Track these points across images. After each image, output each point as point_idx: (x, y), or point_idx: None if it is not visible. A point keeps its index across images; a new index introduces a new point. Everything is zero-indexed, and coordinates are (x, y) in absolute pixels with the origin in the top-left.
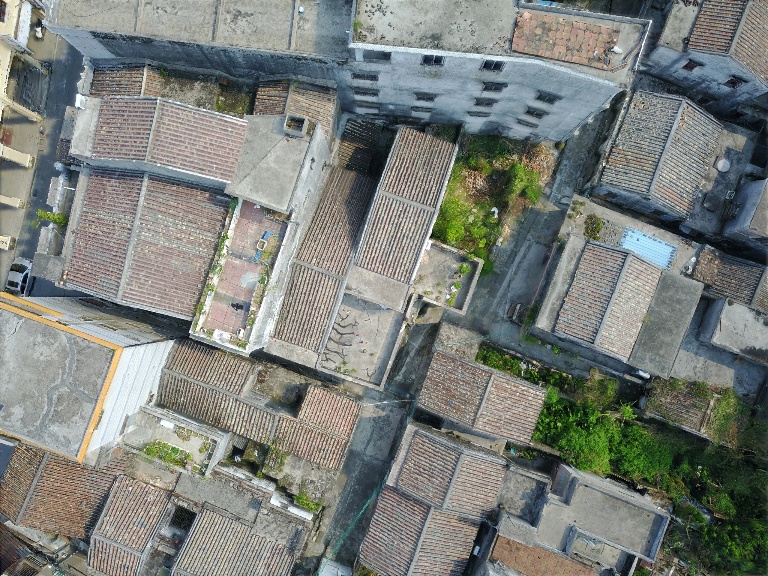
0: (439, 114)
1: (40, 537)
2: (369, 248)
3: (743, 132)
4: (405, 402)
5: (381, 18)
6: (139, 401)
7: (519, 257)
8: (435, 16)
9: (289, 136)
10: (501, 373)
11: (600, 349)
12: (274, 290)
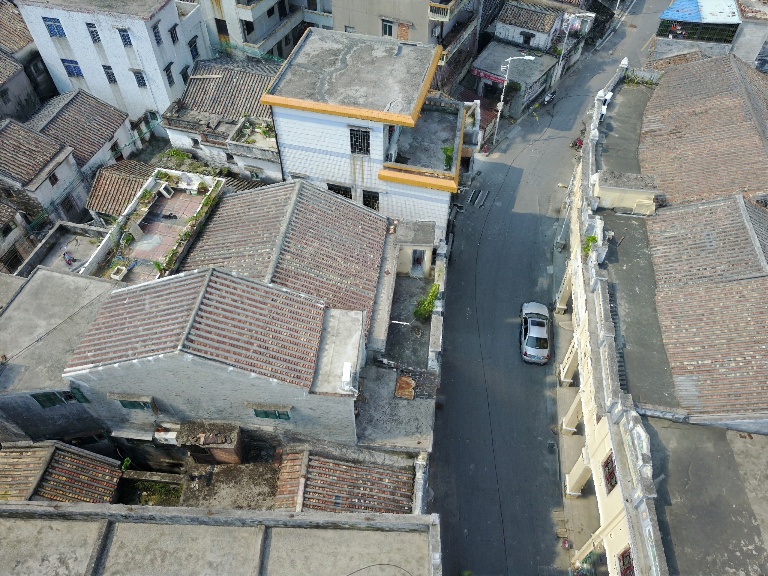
0: None
1: None
2: None
3: None
4: None
5: None
6: None
7: None
8: None
9: None
10: None
11: None
12: None
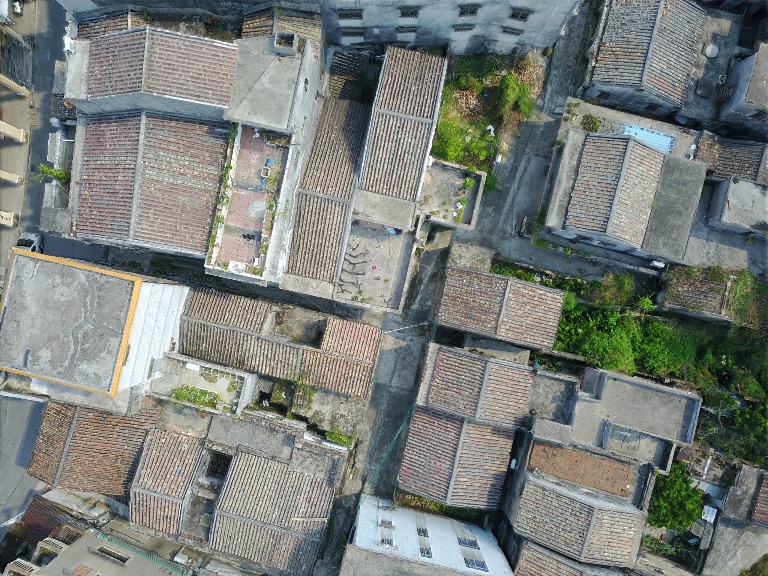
0: (424, 33)
1: (79, 506)
2: (371, 170)
3: (727, 16)
4: (424, 330)
5: None
6: (162, 346)
7: (520, 172)
8: None
9: (280, 55)
10: (517, 280)
11: (613, 237)
12: (283, 219)
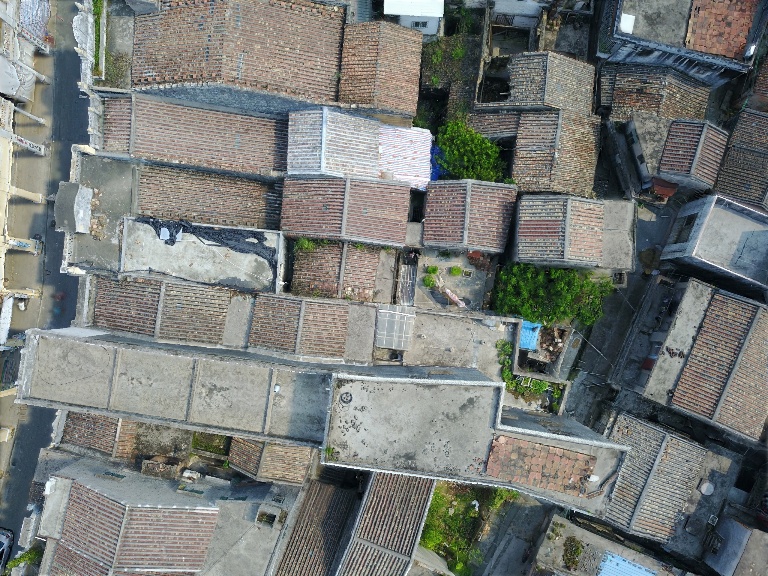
0: None
1: None
2: None
3: (728, 454)
4: None
5: (355, 434)
6: None
7: (499, 551)
8: (409, 434)
9: None
10: None
11: None
12: None
